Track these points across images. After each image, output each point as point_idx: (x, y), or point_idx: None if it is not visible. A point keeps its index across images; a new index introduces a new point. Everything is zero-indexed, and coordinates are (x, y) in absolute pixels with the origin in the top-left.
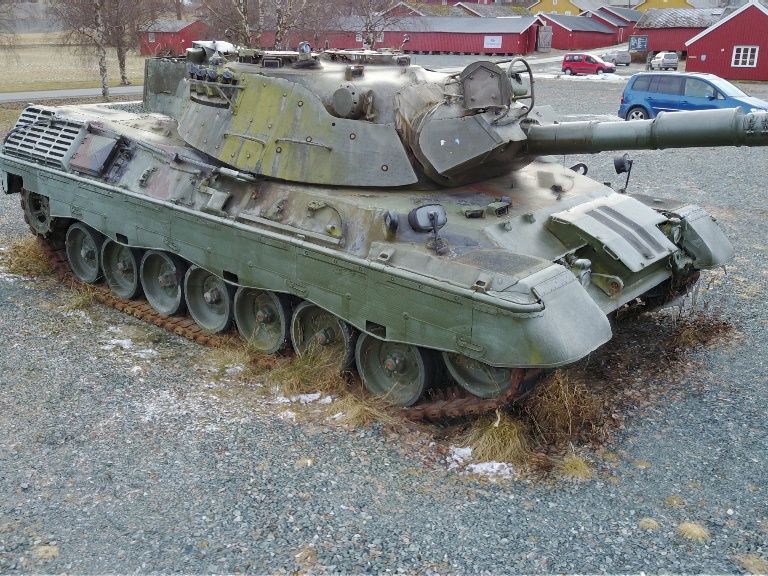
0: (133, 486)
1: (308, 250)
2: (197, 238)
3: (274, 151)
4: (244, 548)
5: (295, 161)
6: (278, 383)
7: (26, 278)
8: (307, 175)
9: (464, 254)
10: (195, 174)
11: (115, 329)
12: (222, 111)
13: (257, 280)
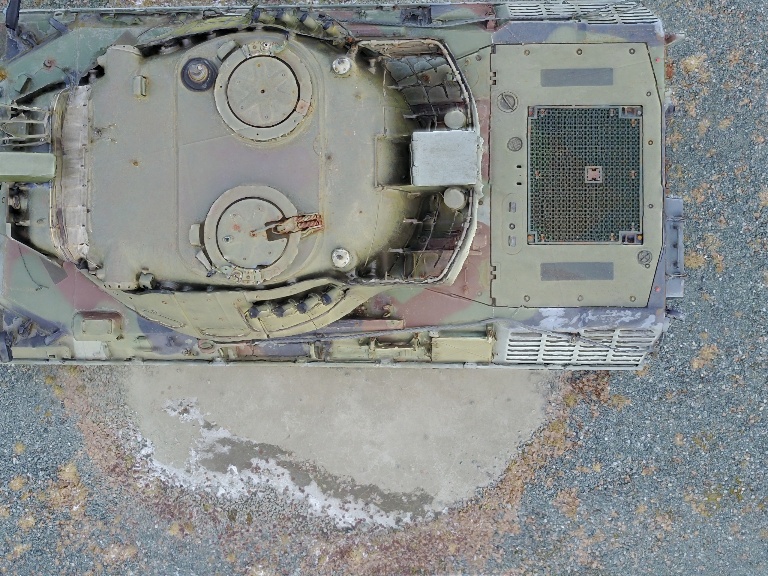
0: None
1: None
2: None
3: None
4: None
5: None
6: None
7: None
8: None
9: (6, 40)
10: None
11: None
12: None
13: None
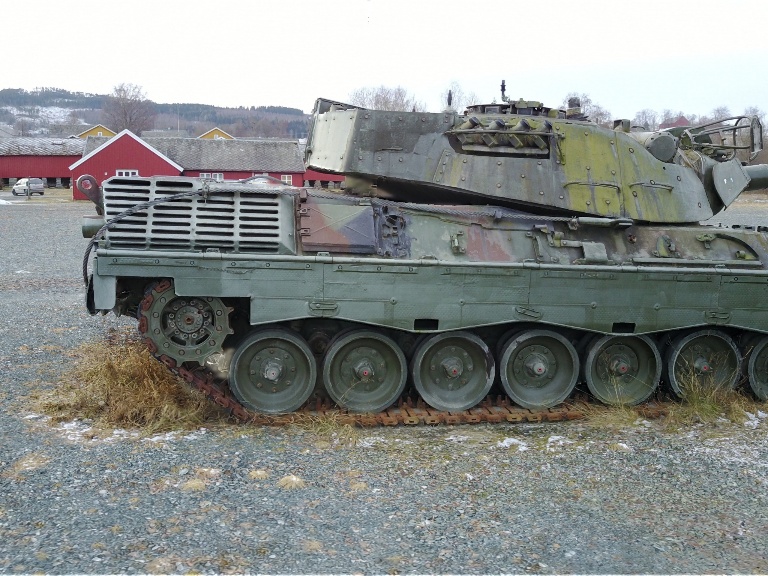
0: None
1: (739, 276)
2: (576, 295)
3: (632, 195)
4: None
5: (651, 203)
6: (716, 415)
7: (198, 431)
8: (663, 215)
9: None
10: (532, 230)
11: (458, 437)
12: (544, 161)
13: (665, 321)
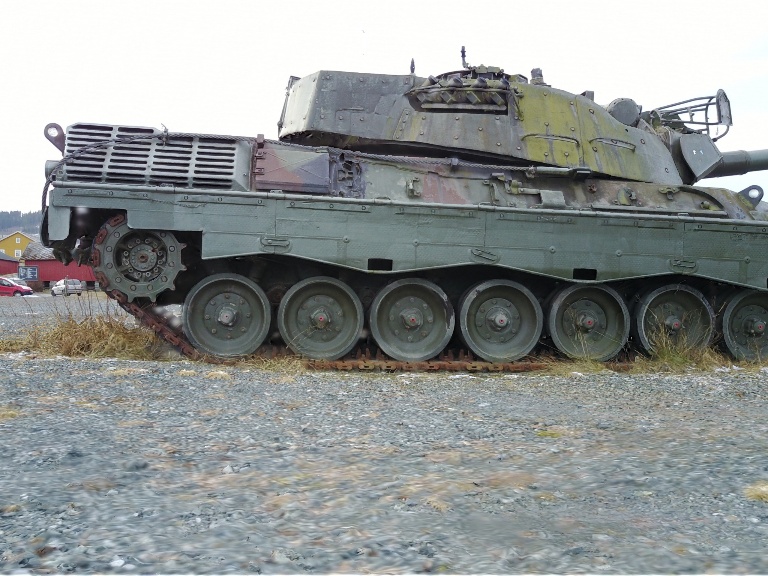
0: None
1: (703, 223)
2: (533, 239)
3: (592, 150)
4: None
5: (612, 159)
6: (687, 365)
7: None
8: (626, 172)
9: None
10: (489, 179)
11: (411, 375)
12: (502, 117)
13: (628, 269)
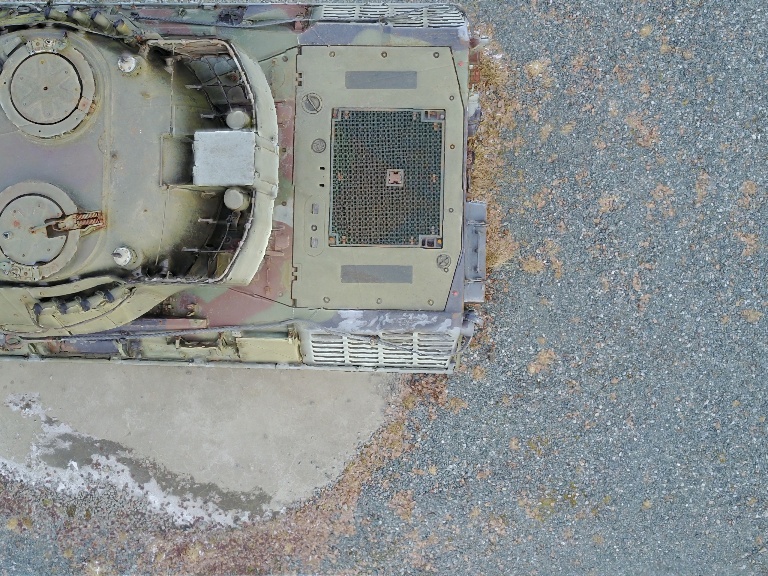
0: None
1: None
2: None
3: None
4: None
5: None
6: None
7: None
8: None
9: None
10: None
11: None
12: None
13: None
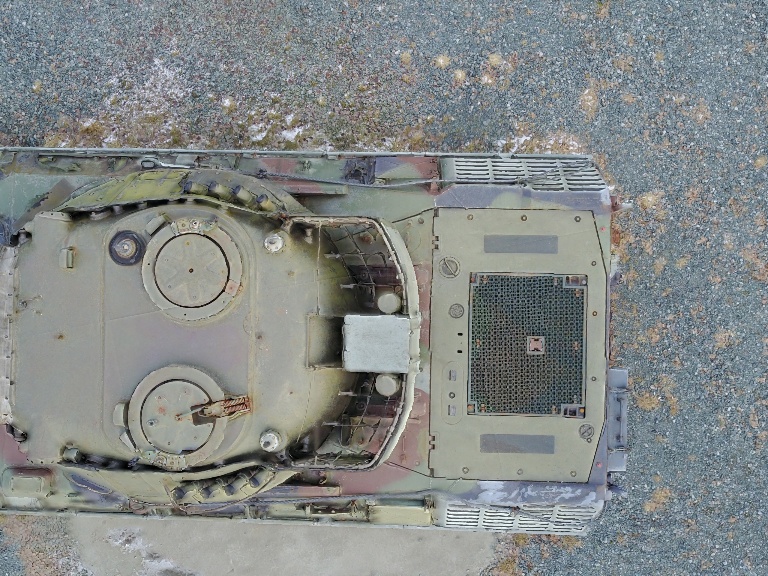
0: (93, 7)
1: None
2: None
3: (126, 179)
4: (4, 9)
5: None
6: None
7: None
8: None
9: None
10: None
11: (325, 148)
12: None
13: None
